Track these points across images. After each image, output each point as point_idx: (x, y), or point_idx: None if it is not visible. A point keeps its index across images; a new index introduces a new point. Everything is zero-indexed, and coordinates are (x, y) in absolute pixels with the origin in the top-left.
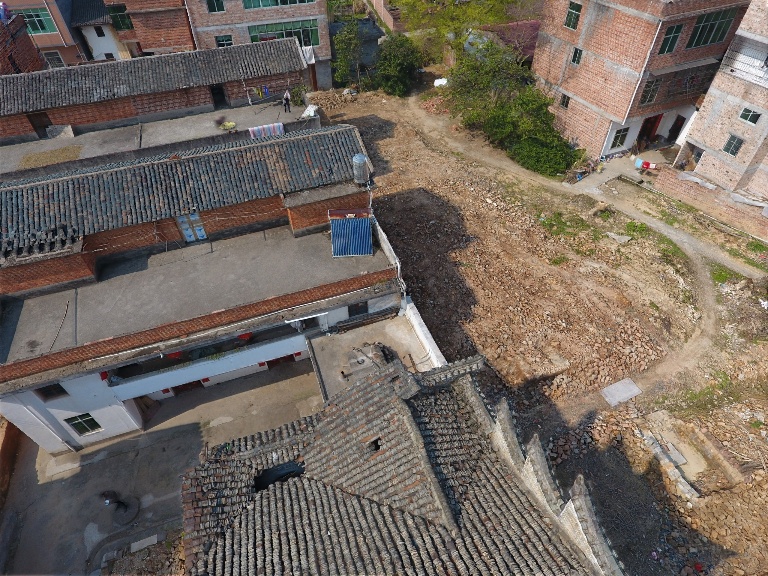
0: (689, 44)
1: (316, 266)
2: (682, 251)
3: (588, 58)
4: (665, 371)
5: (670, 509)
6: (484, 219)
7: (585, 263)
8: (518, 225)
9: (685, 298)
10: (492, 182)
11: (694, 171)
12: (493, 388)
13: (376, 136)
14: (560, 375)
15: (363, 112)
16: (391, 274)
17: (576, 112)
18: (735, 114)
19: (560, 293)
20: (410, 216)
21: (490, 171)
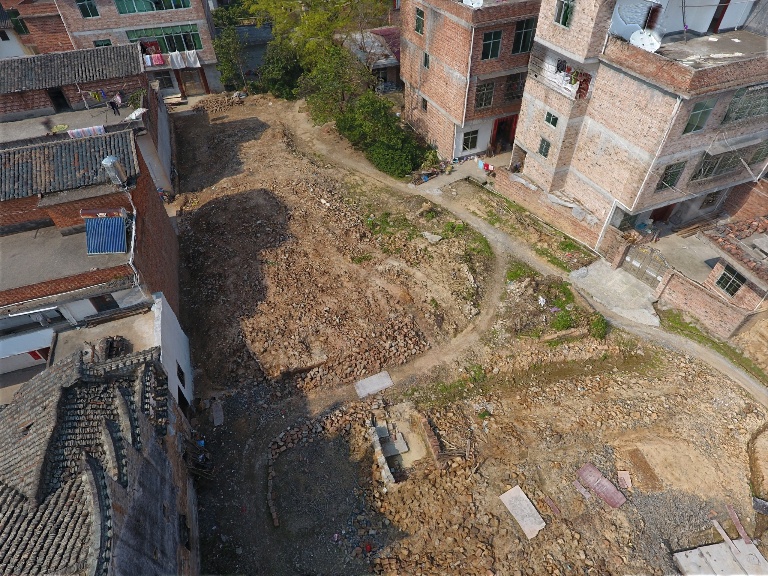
0: (516, 49)
1: (67, 263)
2: (492, 250)
3: (433, 63)
4: (422, 365)
5: (367, 494)
6: (310, 219)
7: (386, 261)
8: (340, 225)
9: (468, 295)
10: (338, 183)
11: (523, 173)
12: (253, 381)
13: (243, 138)
14: (316, 368)
15: (246, 115)
16: (126, 270)
17: (432, 115)
18: (542, 118)
19: (348, 290)
20: (241, 216)
21: (340, 172)
